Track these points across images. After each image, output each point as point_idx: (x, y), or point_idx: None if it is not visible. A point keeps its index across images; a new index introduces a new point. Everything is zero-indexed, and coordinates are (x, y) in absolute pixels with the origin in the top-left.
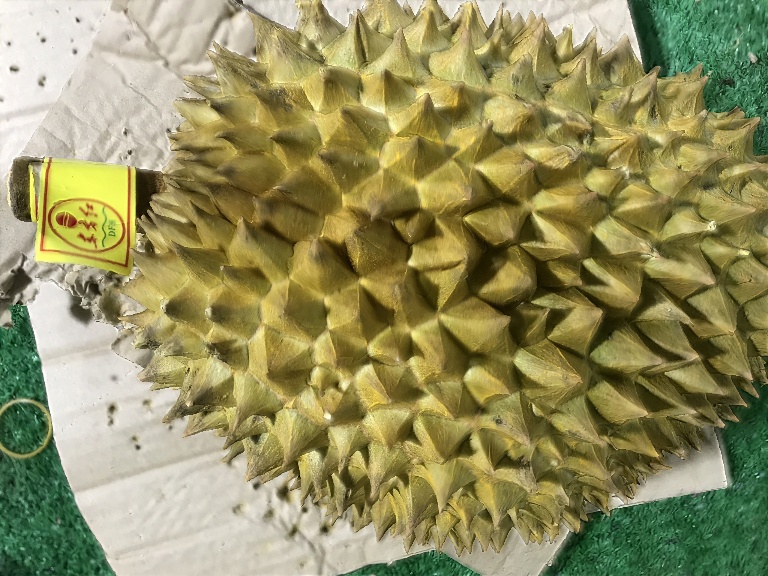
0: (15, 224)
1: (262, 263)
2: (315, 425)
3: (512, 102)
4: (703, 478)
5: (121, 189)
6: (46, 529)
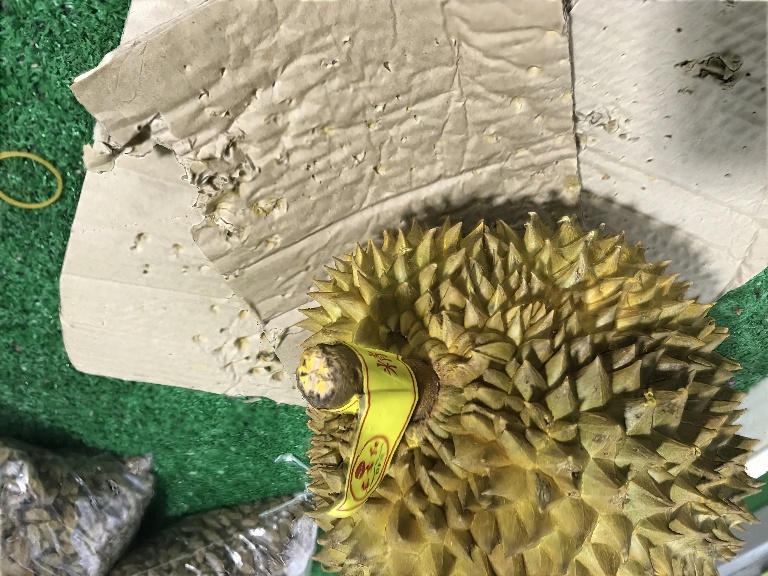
0: (169, 78)
1: None
2: None
3: (679, 574)
4: None
5: (402, 421)
6: (1, 257)
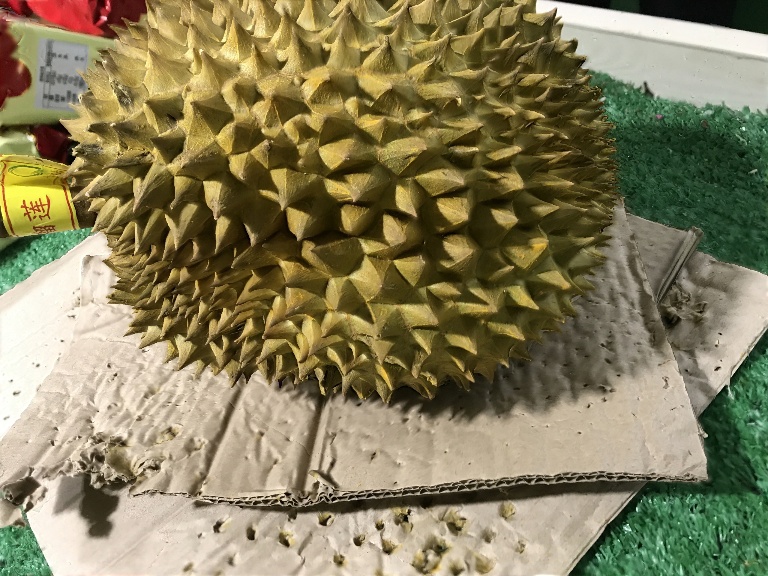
0: (21, 451)
1: (137, 53)
2: (209, 91)
3: None
4: (767, 297)
5: None
6: None
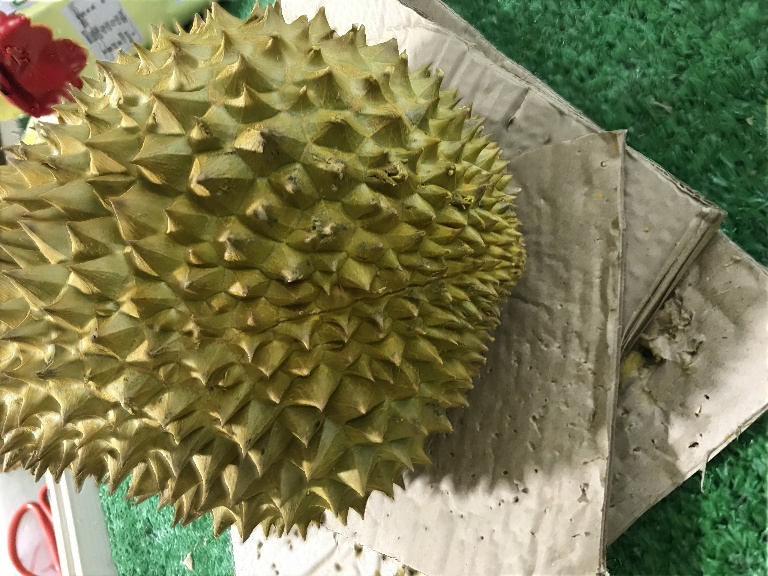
0: None
1: None
2: None
3: None
4: None
5: None
6: None
